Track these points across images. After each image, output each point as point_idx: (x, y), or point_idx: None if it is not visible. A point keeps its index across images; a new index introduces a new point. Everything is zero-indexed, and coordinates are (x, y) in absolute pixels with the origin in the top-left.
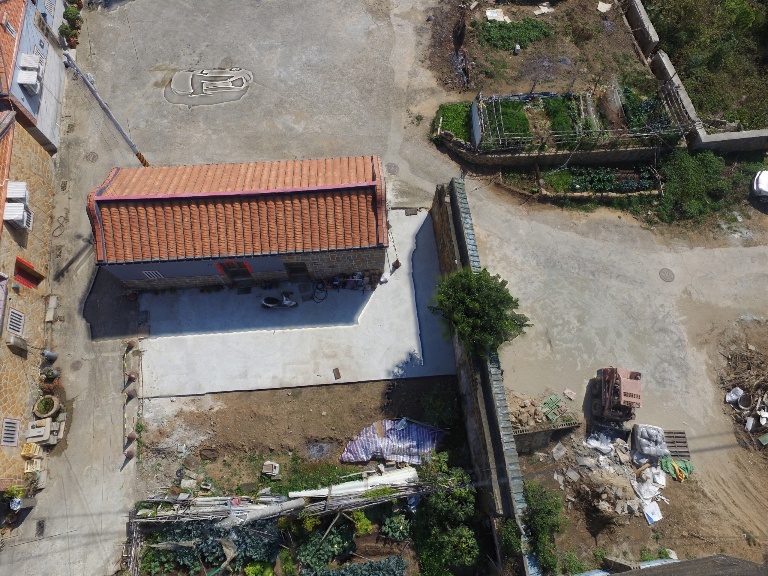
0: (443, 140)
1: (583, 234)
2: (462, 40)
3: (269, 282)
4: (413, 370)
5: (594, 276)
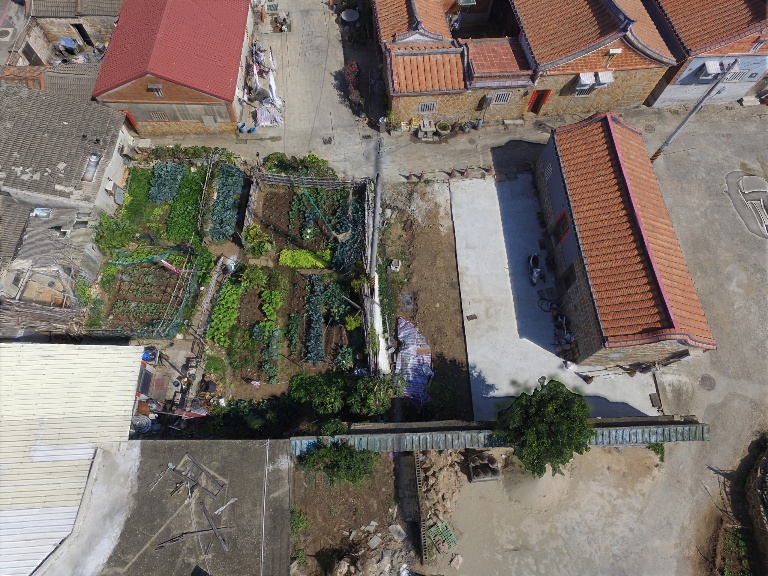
0: (767, 448)
1: None
2: None
3: (553, 262)
4: (478, 386)
5: None
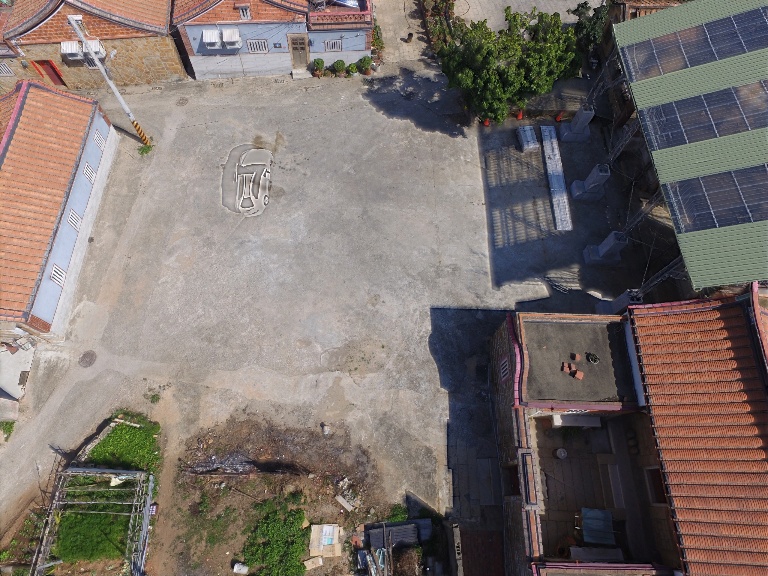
0: None
1: None
2: None
3: None
4: None
5: None
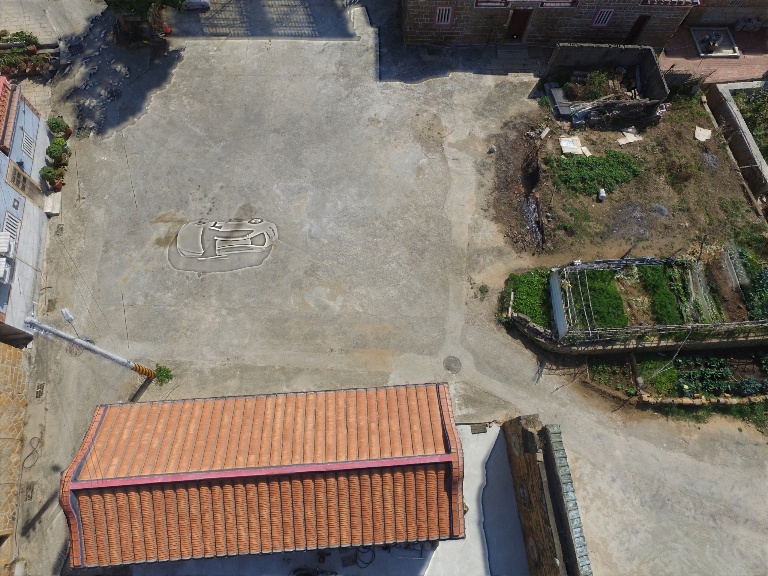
0: (515, 323)
1: (696, 456)
2: (534, 183)
3: None
4: None
5: (715, 522)
